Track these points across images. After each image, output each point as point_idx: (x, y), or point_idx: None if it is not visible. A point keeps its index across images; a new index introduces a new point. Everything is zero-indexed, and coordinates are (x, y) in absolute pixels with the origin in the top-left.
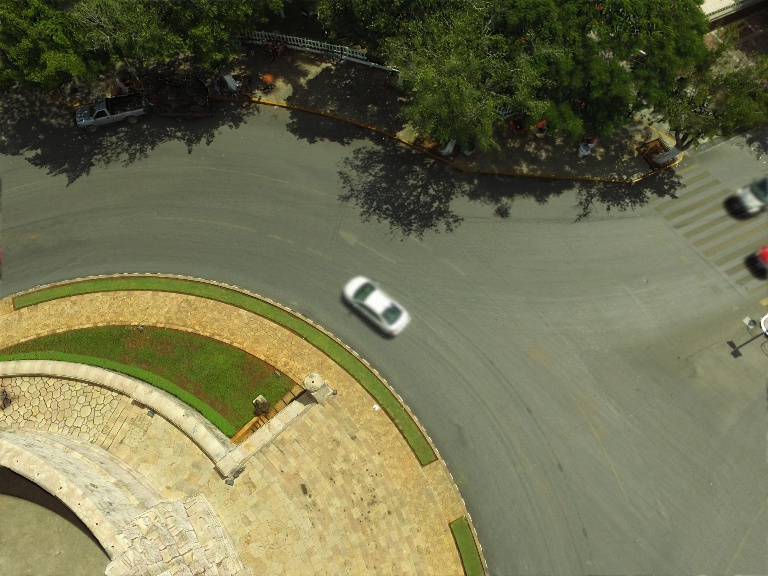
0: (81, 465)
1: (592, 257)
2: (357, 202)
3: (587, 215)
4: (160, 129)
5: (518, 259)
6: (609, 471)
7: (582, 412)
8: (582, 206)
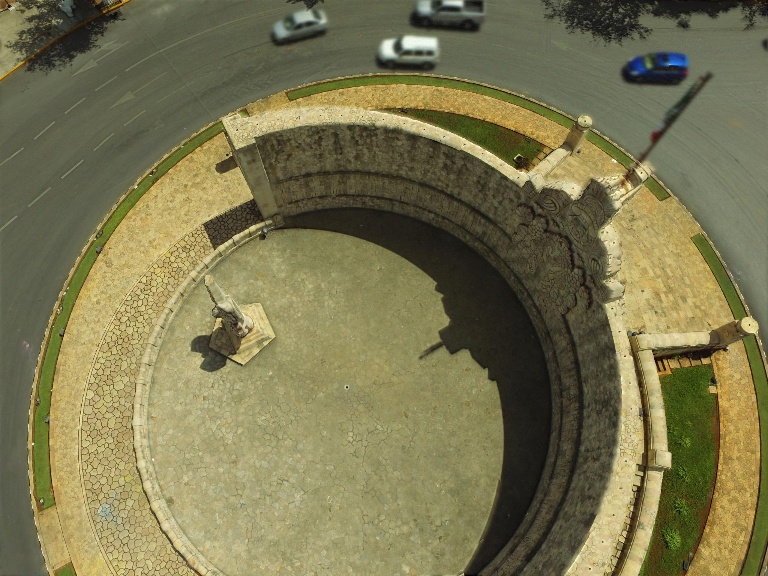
0: None
1: (764, 54)
2: (561, 19)
3: (753, 25)
4: None
5: (704, 57)
6: None
7: None
8: (748, 18)
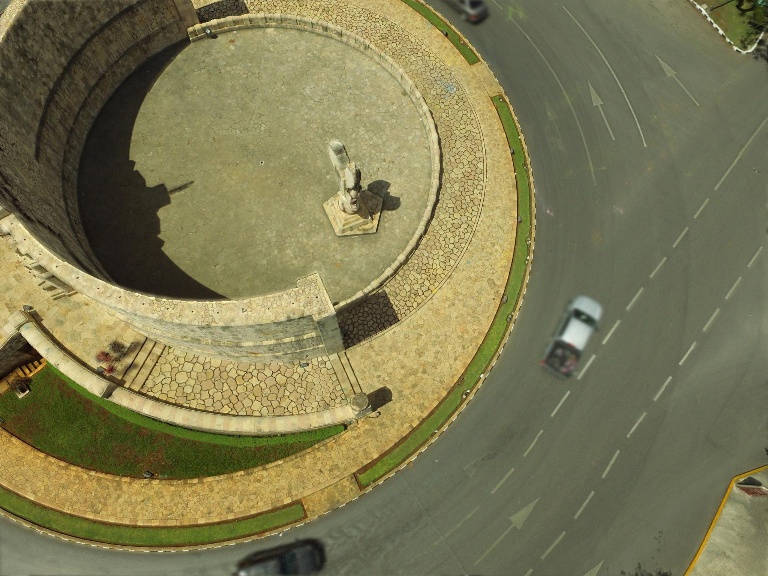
0: None
1: None
2: None
3: None
4: None
5: None
6: None
7: None
8: None
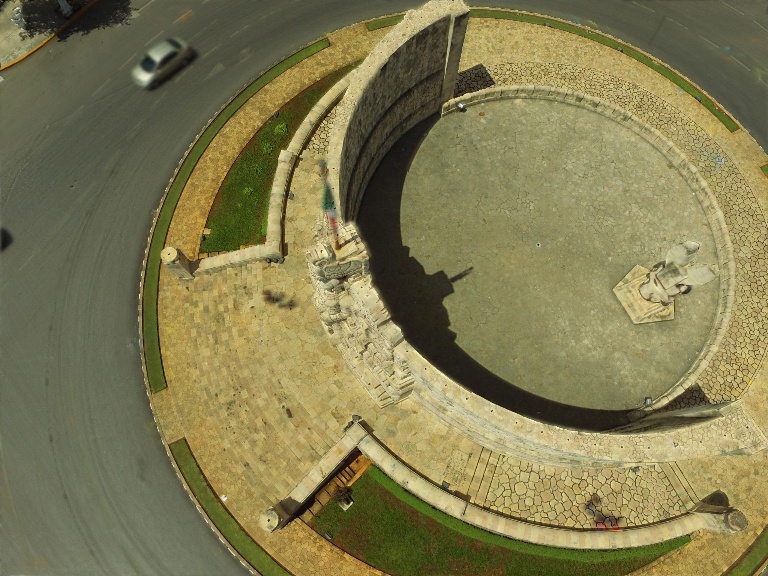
0: (477, 426)
1: None
2: None
3: None
4: None
5: None
6: (5, 435)
7: (10, 495)
8: None
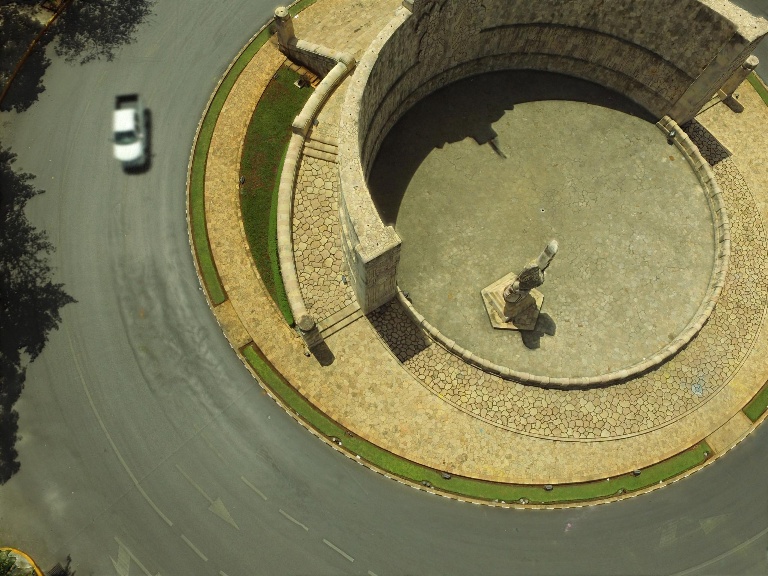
0: None
1: None
2: (116, 47)
3: None
4: (7, 227)
5: None
6: None
7: None
8: None
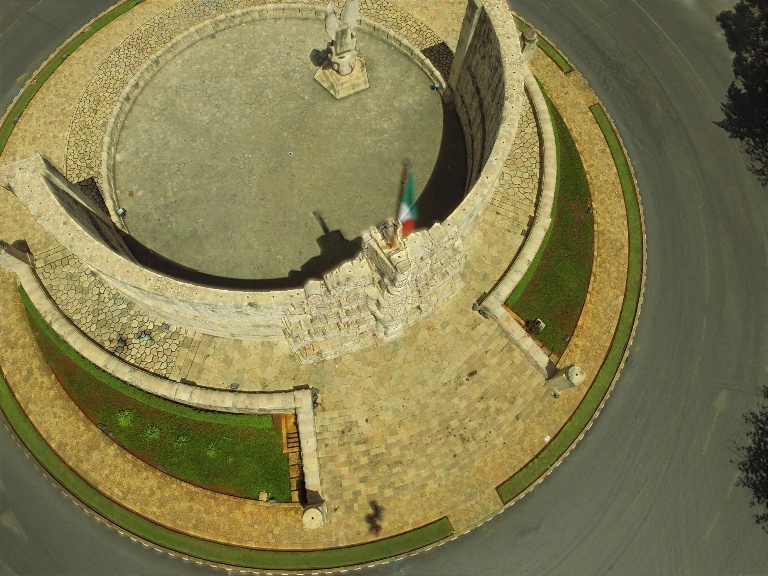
0: None
1: None
2: (766, 408)
3: None
4: None
5: None
6: None
7: None
8: None
